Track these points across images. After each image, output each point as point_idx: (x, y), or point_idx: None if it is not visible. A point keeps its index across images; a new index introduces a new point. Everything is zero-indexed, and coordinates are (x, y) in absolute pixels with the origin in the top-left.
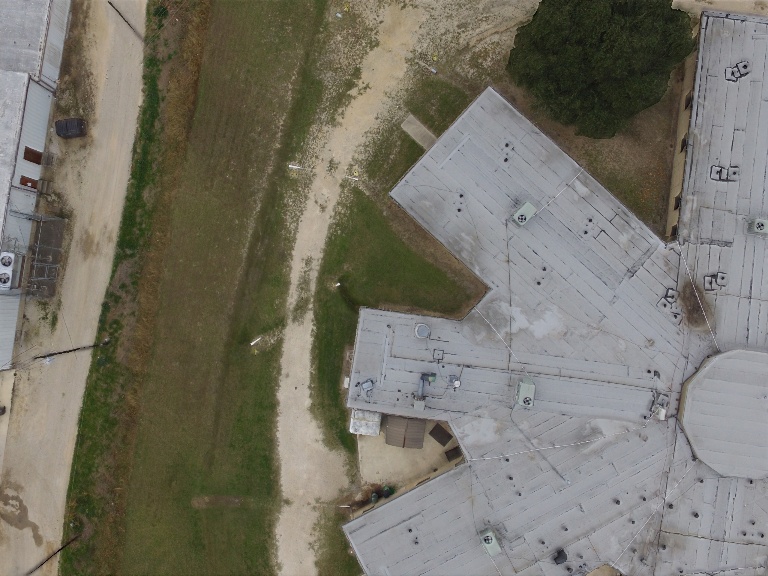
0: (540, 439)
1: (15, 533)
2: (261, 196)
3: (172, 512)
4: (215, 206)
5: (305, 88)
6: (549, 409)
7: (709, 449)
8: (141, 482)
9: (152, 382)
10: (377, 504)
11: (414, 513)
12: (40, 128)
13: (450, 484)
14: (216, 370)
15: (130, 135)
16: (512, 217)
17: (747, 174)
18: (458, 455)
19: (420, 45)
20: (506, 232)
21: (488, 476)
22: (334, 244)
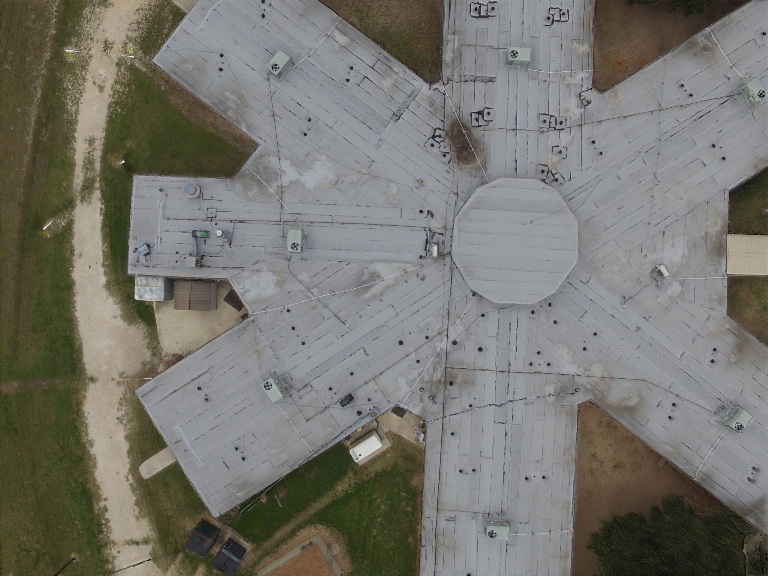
0: (320, 288)
1: None
2: (41, 83)
3: None
4: None
5: None
6: (325, 257)
7: (480, 278)
8: None
9: None
10: None
11: (202, 371)
12: None
13: (235, 340)
14: (11, 257)
15: None
16: None
17: (506, 8)
18: None
19: None
20: (269, 87)
21: (271, 328)
22: (115, 122)
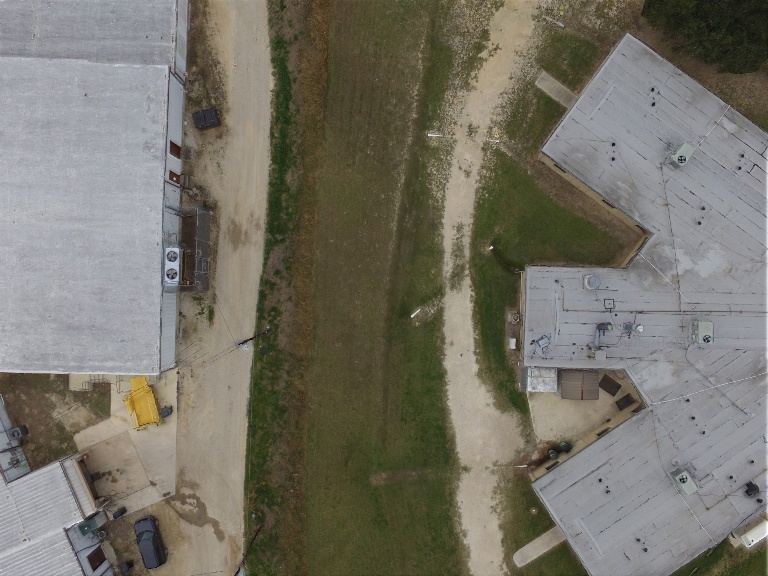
0: (717, 376)
1: (196, 531)
2: (404, 168)
3: (351, 492)
4: (359, 183)
5: (435, 56)
6: (723, 346)
7: None
8: (317, 466)
9: (317, 365)
10: (561, 459)
11: (601, 463)
12: (178, 122)
13: (634, 430)
14: (379, 346)
15: (265, 121)
16: (670, 159)
17: None
18: (629, 403)
19: (545, 1)
20: (662, 176)
21: (670, 418)
22: (483, 208)
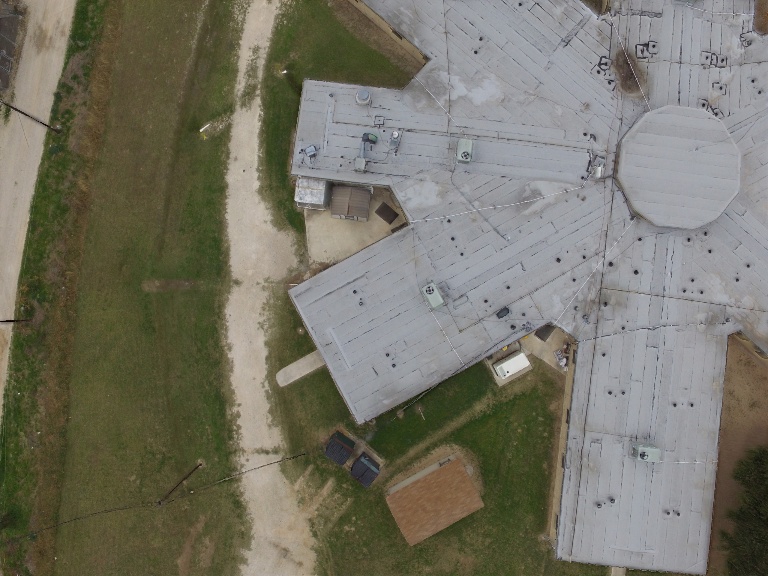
0: (481, 201)
1: None
2: None
3: (122, 295)
4: (165, 1)
5: None
6: (488, 171)
7: (644, 200)
8: (92, 267)
9: (103, 169)
10: None
11: (358, 275)
12: None
13: (393, 246)
14: (166, 156)
15: None
16: None
17: None
18: None
19: None
20: (443, 5)
21: (430, 237)
22: (280, 33)
